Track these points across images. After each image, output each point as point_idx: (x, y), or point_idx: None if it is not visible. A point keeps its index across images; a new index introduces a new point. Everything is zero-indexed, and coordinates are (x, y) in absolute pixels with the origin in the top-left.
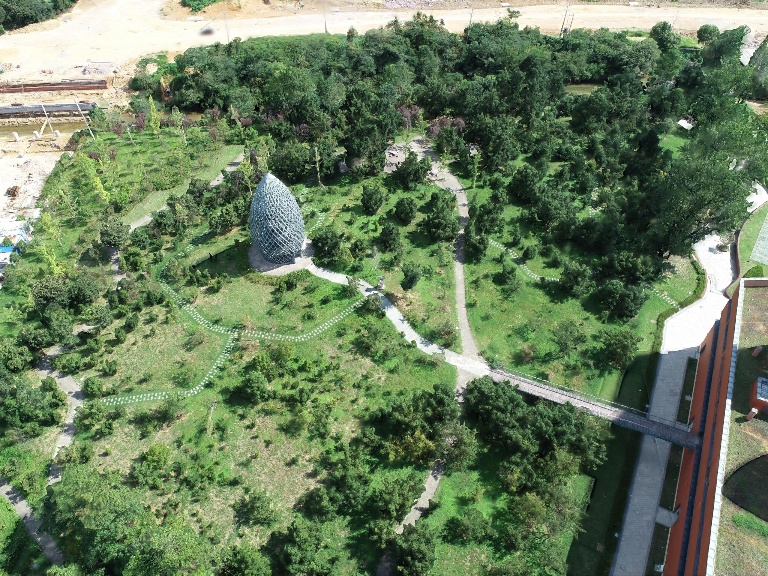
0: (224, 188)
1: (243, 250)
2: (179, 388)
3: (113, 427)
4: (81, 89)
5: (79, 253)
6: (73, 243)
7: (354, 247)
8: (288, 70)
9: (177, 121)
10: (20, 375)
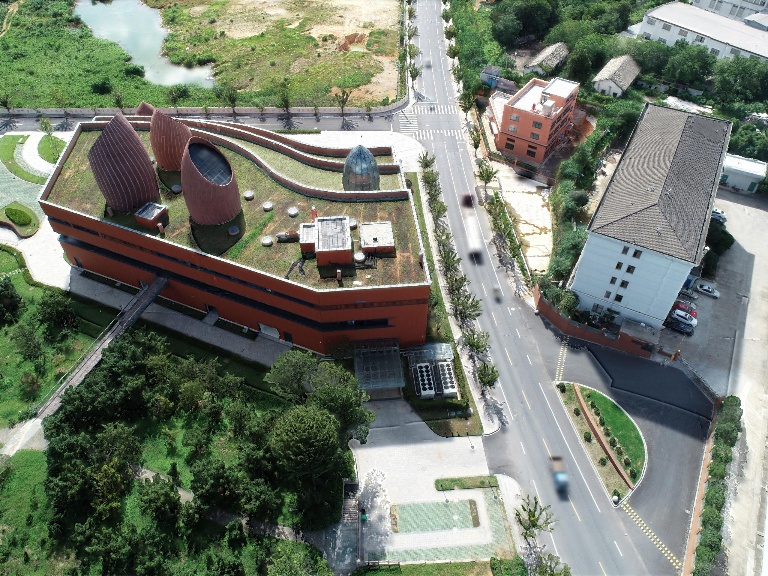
0: None
1: None
2: None
3: None
4: None
5: None
6: None
7: None
8: None
9: None
10: None
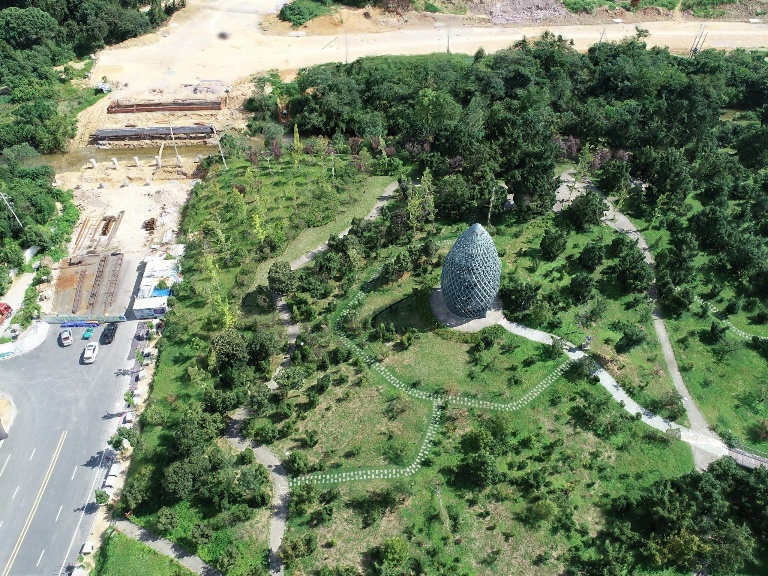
0: (385, 227)
1: (425, 301)
2: (393, 465)
3: (332, 512)
4: (194, 110)
5: (240, 298)
6: (235, 288)
7: (548, 300)
8: (439, 97)
9: (321, 151)
10: (210, 443)
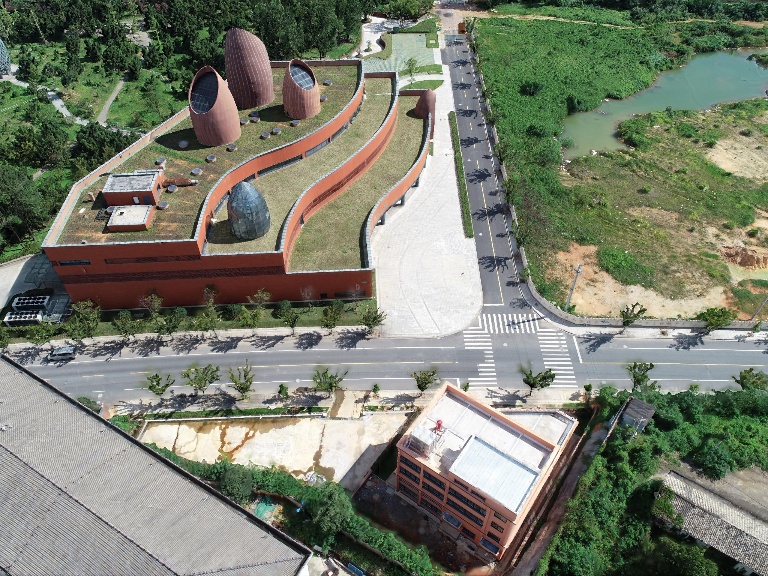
0: None
1: None
2: None
3: None
4: None
5: None
6: None
7: (45, 68)
8: None
9: None
10: None
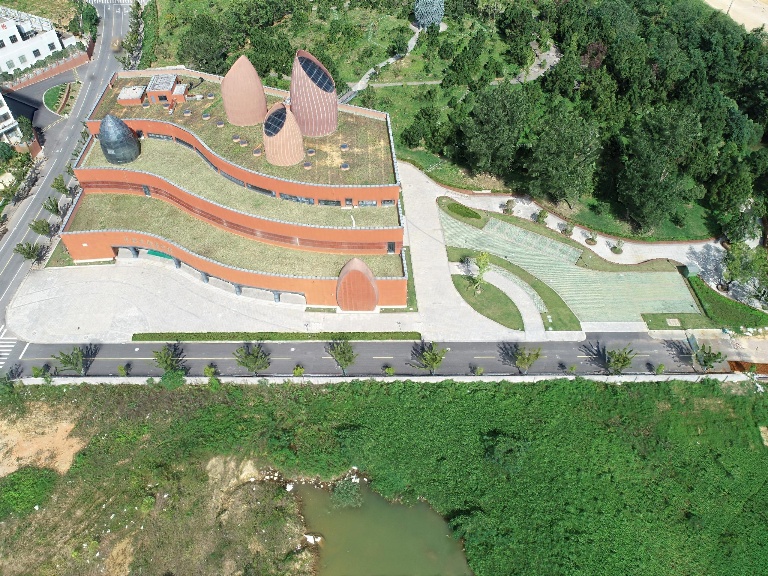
0: None
1: None
2: None
3: None
4: None
5: None
6: None
7: None
8: None
9: None
10: None
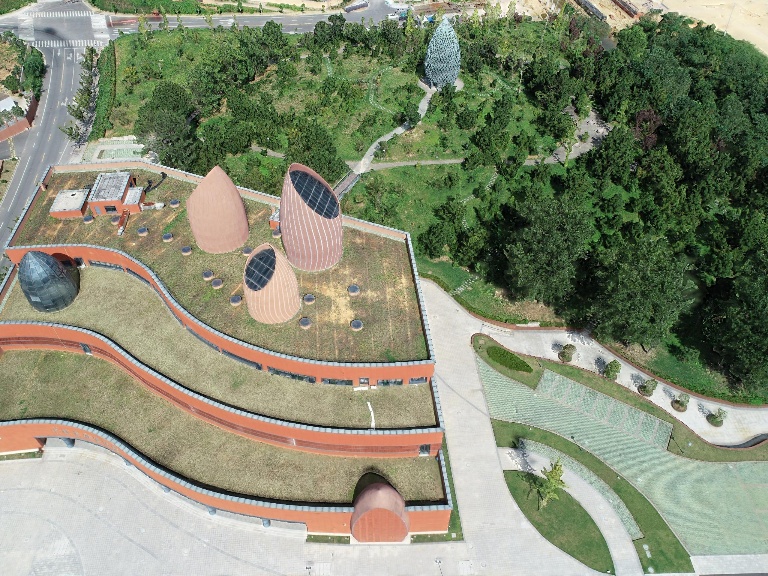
0: (501, 58)
1: None
2: None
3: None
4: (624, 10)
5: None
6: None
7: None
8: None
9: (562, 25)
10: (344, 41)
